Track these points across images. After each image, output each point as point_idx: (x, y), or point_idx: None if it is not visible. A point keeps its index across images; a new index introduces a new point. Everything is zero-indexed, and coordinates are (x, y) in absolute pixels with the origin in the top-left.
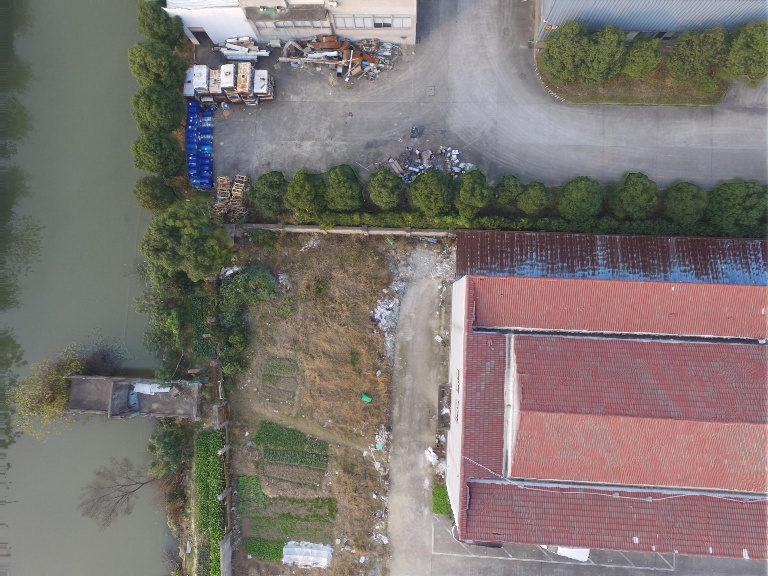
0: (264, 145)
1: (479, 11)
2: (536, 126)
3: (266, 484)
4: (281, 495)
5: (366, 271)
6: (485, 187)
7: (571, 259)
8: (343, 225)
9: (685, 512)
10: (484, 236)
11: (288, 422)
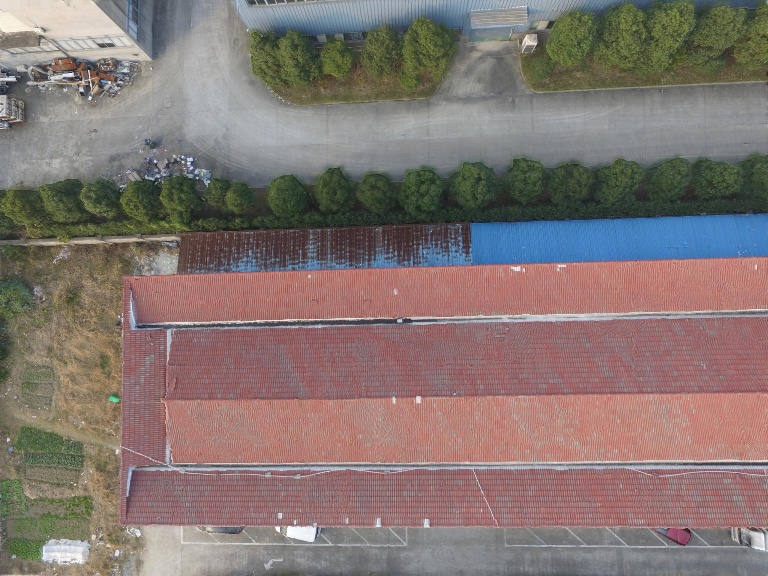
0: (17, 165)
1: (211, 24)
2: (265, 129)
3: (27, 486)
4: (41, 496)
5: (112, 278)
6: (184, 192)
7: (284, 254)
8: (80, 236)
9: (336, 487)
10: (206, 238)
11: (46, 426)
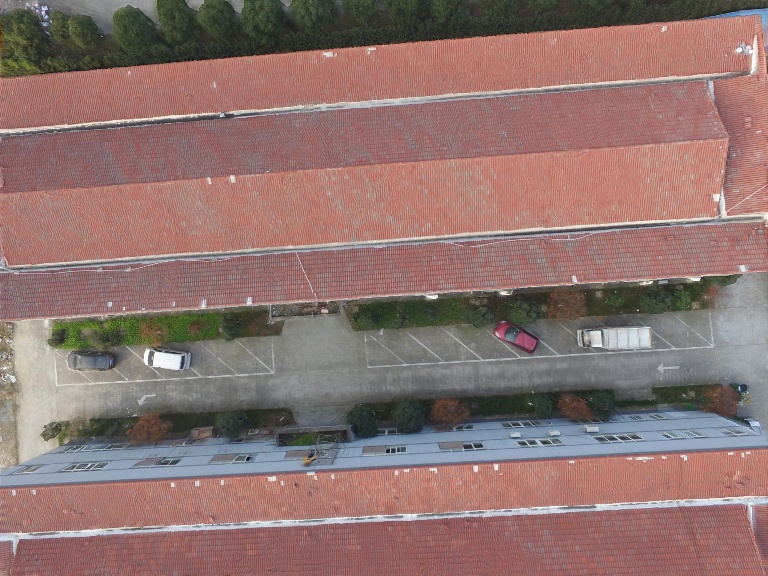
0: None
1: None
2: None
3: None
4: None
5: None
6: (25, 22)
7: None
8: None
9: None
10: None
11: None
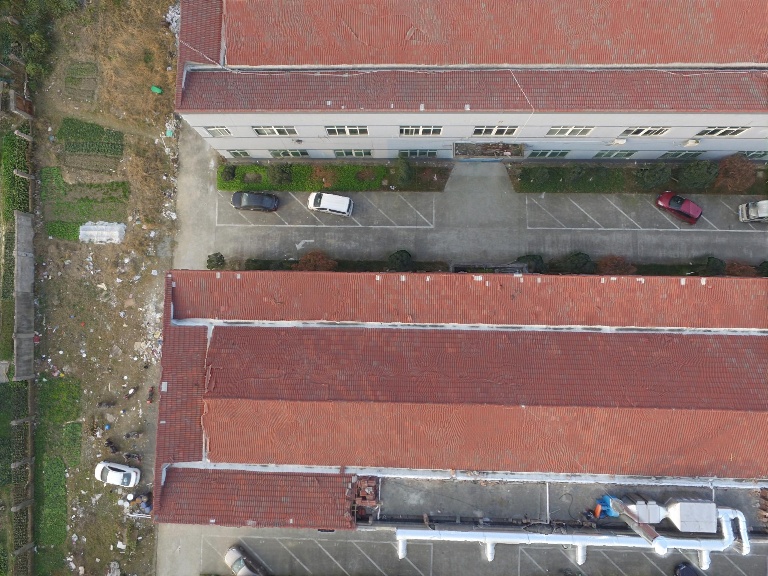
0: None
1: None
2: None
3: (66, 172)
4: (80, 181)
5: None
6: None
7: None
8: None
9: None
10: None
11: (88, 118)
